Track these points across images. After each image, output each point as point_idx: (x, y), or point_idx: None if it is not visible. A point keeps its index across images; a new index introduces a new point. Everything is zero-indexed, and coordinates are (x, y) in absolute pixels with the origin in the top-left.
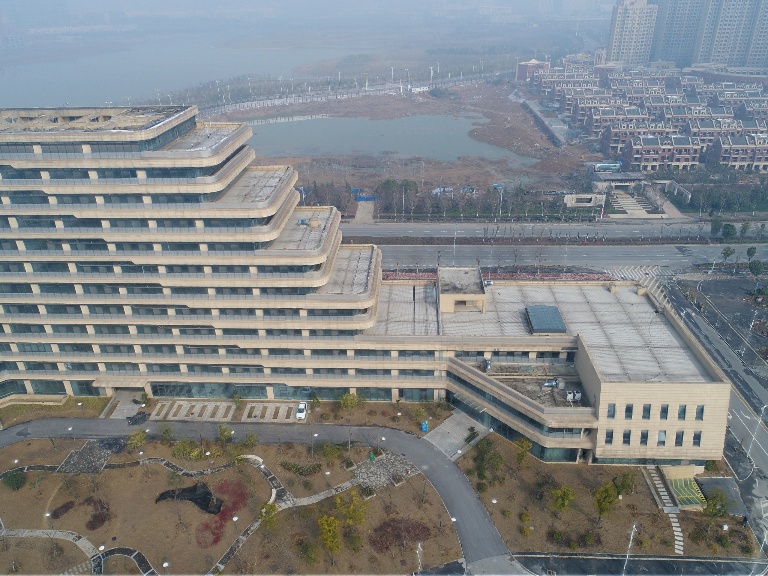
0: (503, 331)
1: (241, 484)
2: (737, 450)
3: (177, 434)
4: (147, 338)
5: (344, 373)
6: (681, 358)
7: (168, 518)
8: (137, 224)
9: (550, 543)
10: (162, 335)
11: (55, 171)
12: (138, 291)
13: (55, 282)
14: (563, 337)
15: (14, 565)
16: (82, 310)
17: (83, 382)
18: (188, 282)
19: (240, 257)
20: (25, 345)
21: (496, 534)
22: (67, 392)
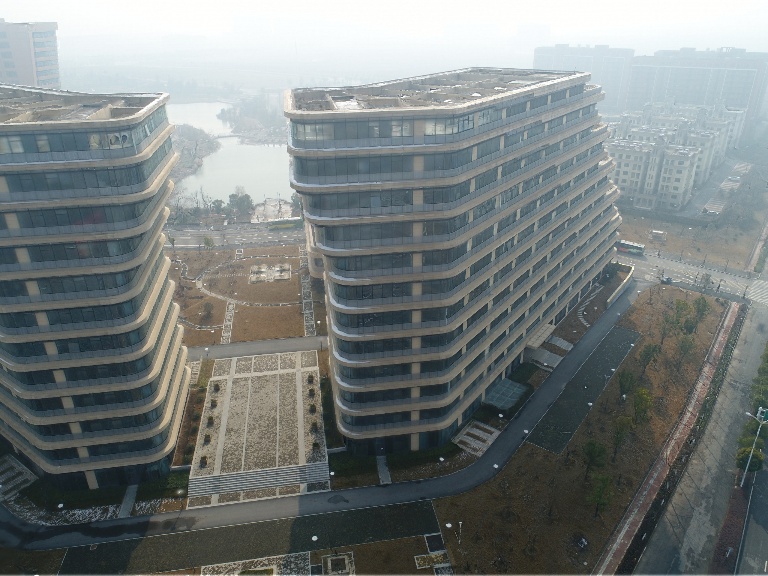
0: None
1: None
2: None
3: None
4: None
5: None
6: None
7: None
8: None
9: None
10: None
11: None
12: None
13: None
14: None
15: (232, 282)
16: None
17: None
18: None
19: None
20: None
21: None
22: None
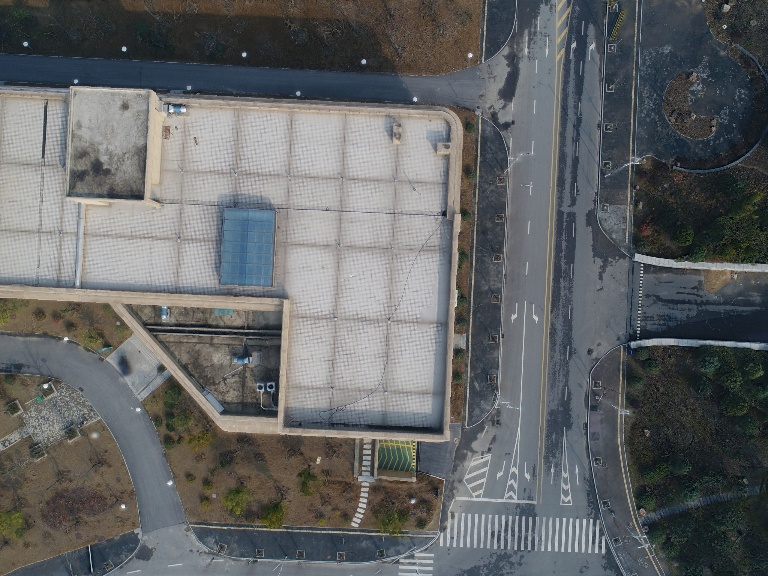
0: (179, 268)
1: None
2: (489, 380)
3: None
4: None
5: None
6: (424, 352)
7: None
8: None
9: (229, 514)
10: None
11: None
12: None
13: None
14: (263, 302)
15: None
16: None
17: None
18: None
19: None
20: None
21: (177, 501)
22: None
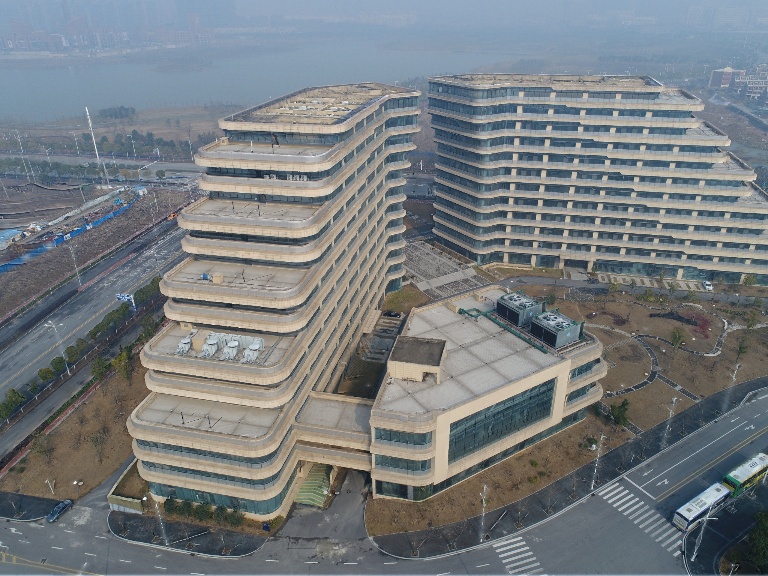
0: None
1: (699, 315)
2: None
3: (628, 290)
4: (606, 227)
5: (742, 262)
6: None
7: (666, 325)
8: (632, 147)
9: None
10: (617, 226)
11: (591, 110)
12: (613, 194)
13: (560, 184)
14: None
15: None
16: (568, 205)
17: (546, 257)
18: (654, 189)
19: (698, 173)
20: (516, 228)
21: None
22: (532, 263)
